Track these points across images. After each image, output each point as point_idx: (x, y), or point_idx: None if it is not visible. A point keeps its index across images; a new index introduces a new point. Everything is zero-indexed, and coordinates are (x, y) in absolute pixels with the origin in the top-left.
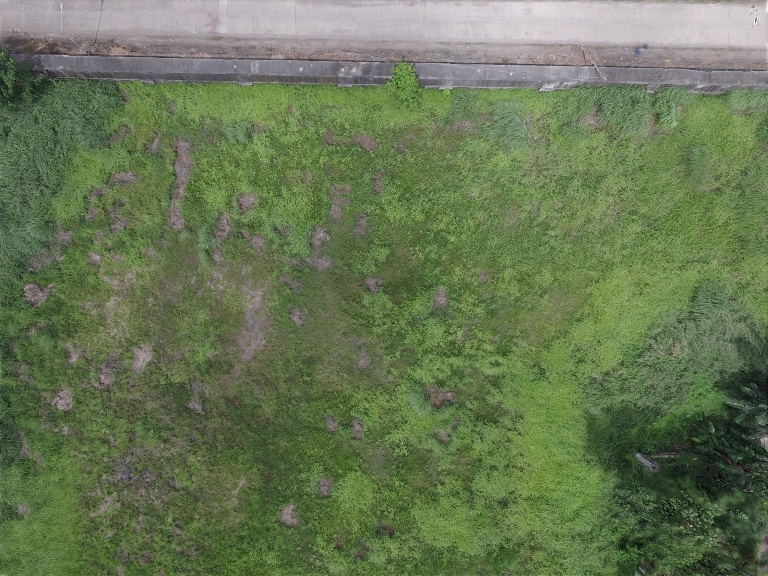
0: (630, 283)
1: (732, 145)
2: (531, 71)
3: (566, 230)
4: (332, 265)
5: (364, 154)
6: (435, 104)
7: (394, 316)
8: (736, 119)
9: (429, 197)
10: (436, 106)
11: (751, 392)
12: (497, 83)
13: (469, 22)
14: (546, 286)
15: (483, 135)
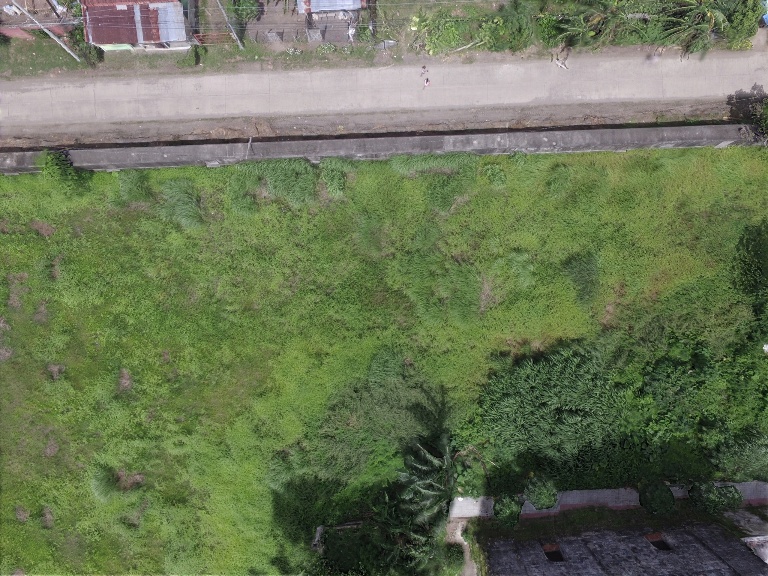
0: (311, 354)
1: (405, 209)
2: (185, 151)
3: (246, 304)
4: (14, 354)
5: (40, 241)
6: (106, 187)
7: (79, 402)
8: (407, 183)
9: (106, 280)
10: (106, 189)
11: (414, 461)
12: (159, 164)
13: (140, 100)
14: (228, 362)
15: (156, 214)
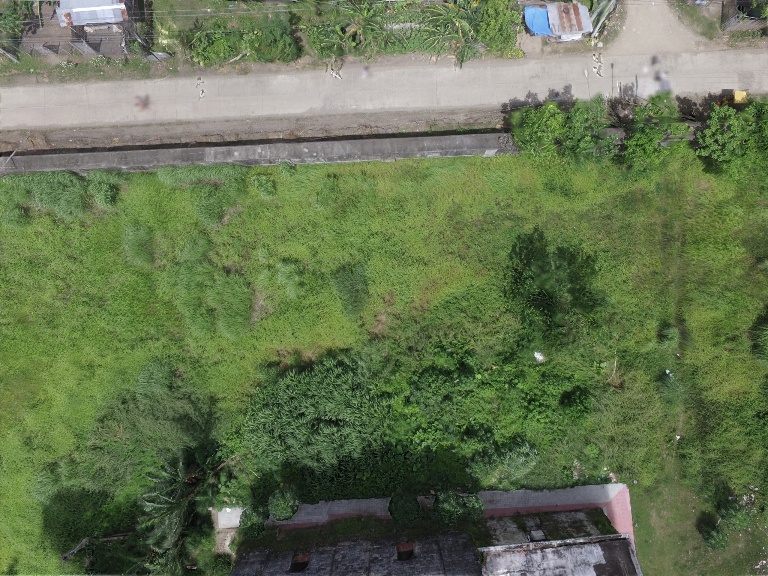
0: (83, 366)
1: (176, 220)
2: None
3: (21, 317)
4: None
5: None
6: None
7: None
8: (178, 194)
9: None
10: None
11: None
12: None
13: None
14: (2, 374)
15: None
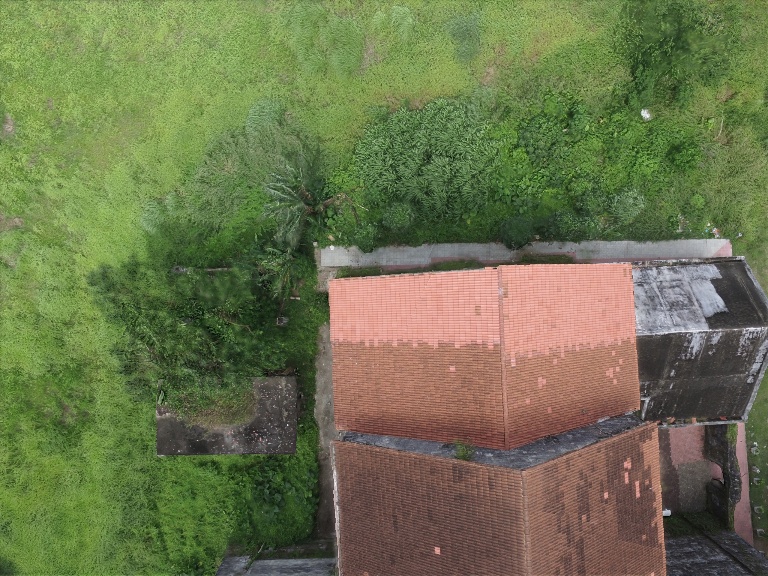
0: (192, 104)
1: None
2: None
3: (131, 55)
4: None
5: None
6: None
7: None
8: None
9: None
10: None
11: None
12: None
13: None
14: (111, 110)
15: None
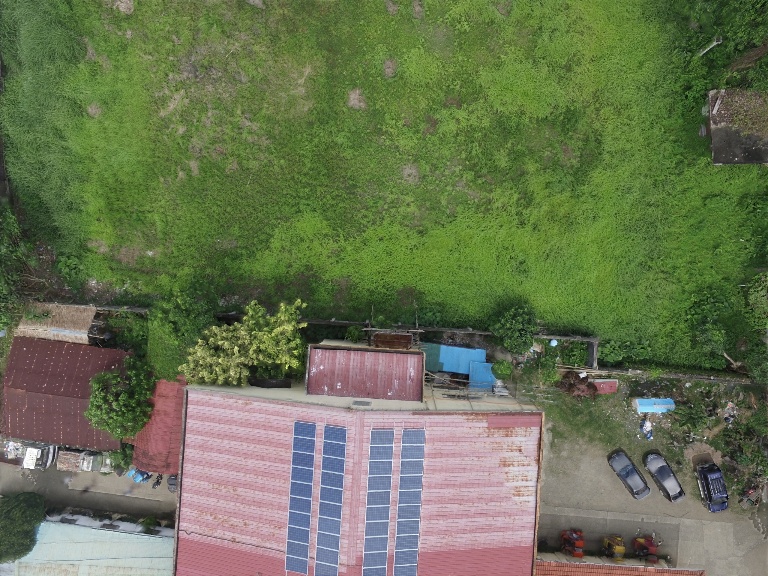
0: None
1: None
2: None
3: None
4: None
5: None
6: None
7: None
8: None
9: None
10: None
11: None
12: None
13: None
14: None
15: None
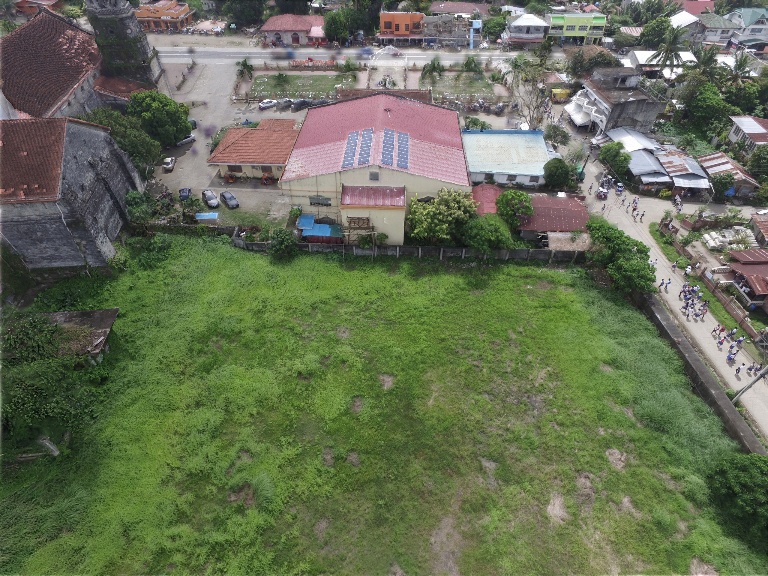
0: None
1: None
2: None
3: None
4: None
5: None
6: None
7: None
8: None
9: None
10: None
11: None
12: None
13: None
14: None
15: None
